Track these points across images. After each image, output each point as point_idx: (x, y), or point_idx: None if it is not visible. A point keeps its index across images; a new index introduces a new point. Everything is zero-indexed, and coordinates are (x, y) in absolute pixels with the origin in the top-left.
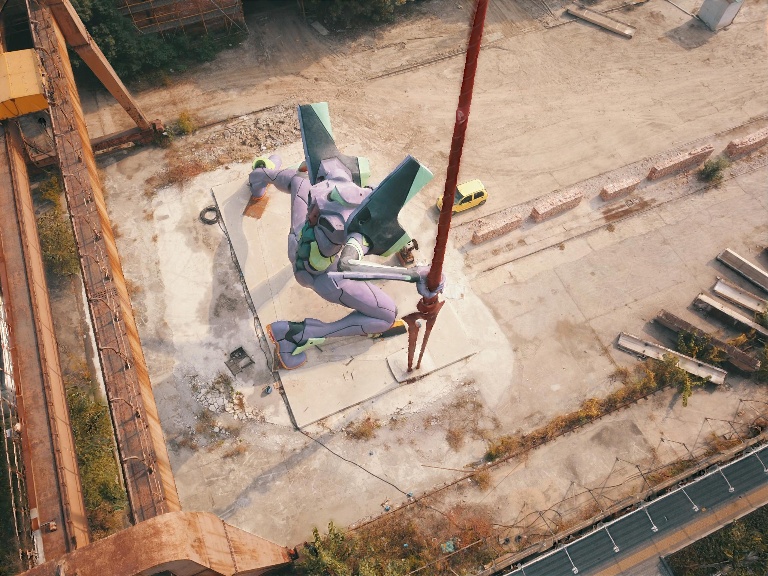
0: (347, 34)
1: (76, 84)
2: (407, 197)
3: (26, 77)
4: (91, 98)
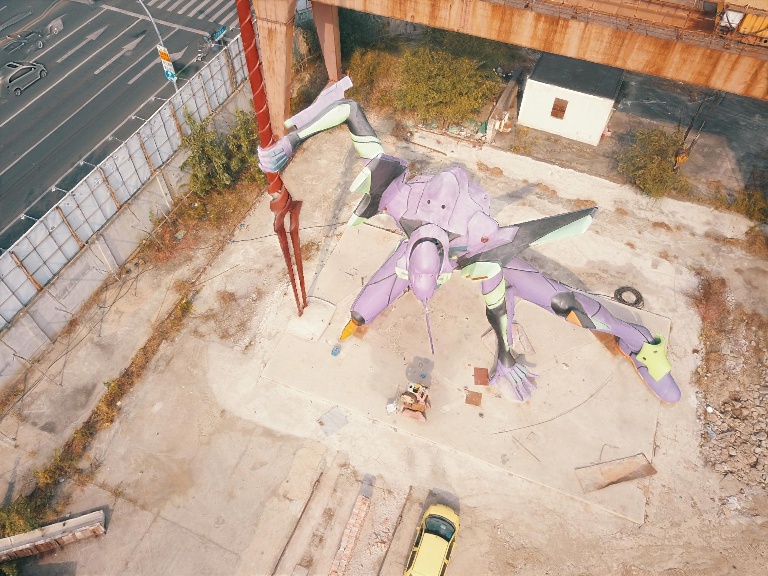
0: None
1: None
2: None
3: (758, 6)
4: None
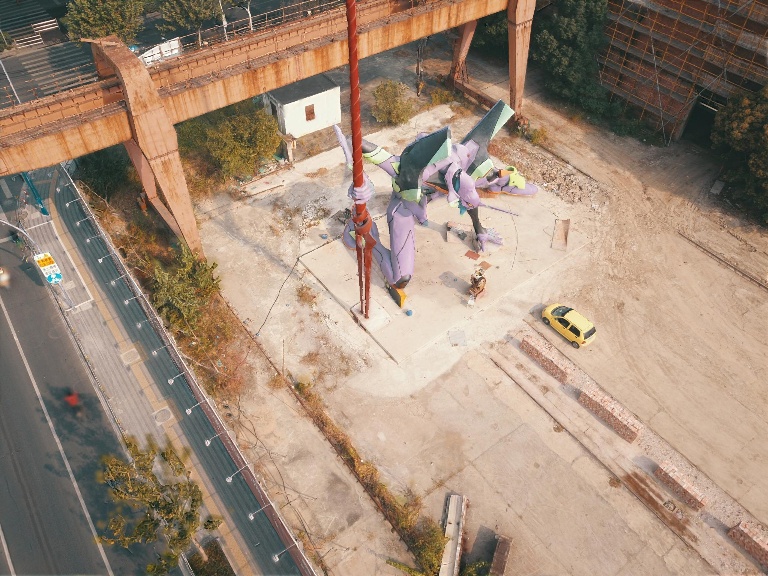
0: (727, 206)
1: (541, 82)
2: (431, 159)
3: None
4: (533, 92)
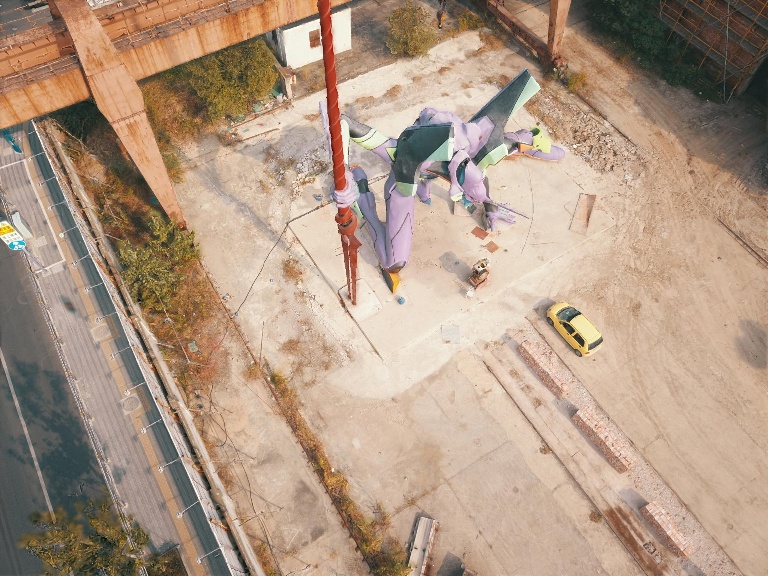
0: None
1: (590, 6)
2: (430, 156)
3: None
4: (579, 19)
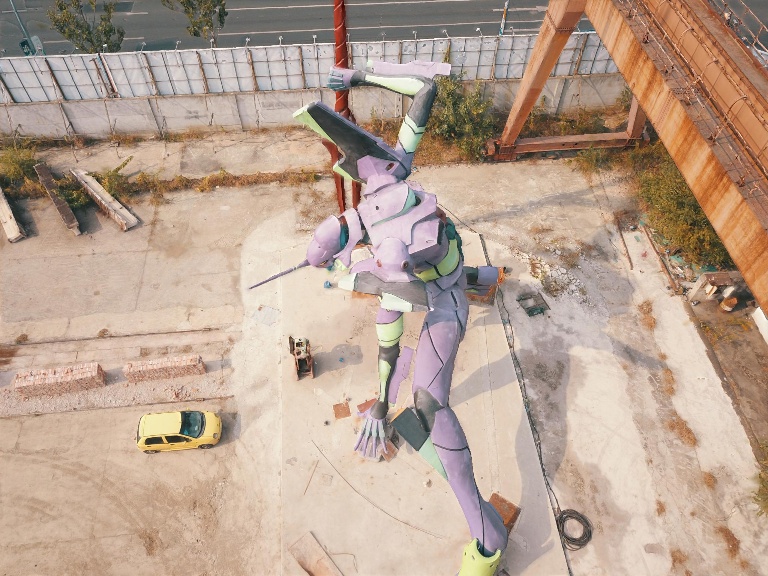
0: None
1: None
2: None
3: None
4: None
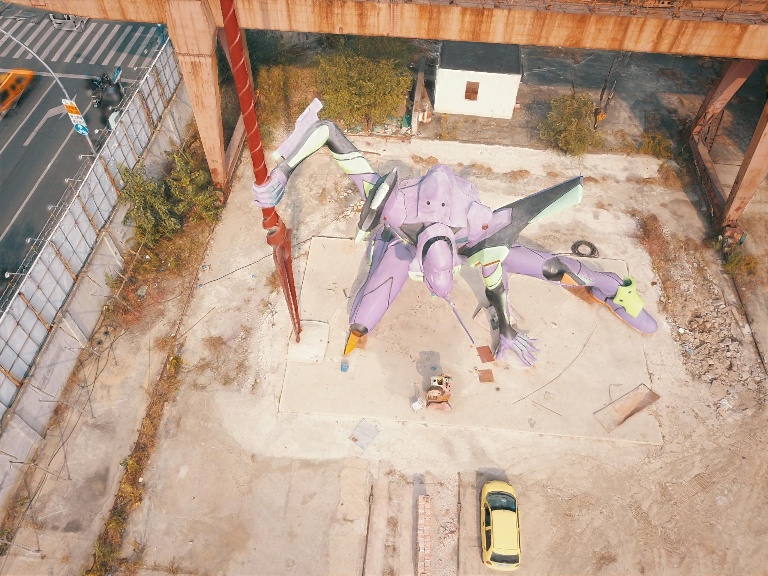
0: None
1: None
2: None
3: None
4: None
